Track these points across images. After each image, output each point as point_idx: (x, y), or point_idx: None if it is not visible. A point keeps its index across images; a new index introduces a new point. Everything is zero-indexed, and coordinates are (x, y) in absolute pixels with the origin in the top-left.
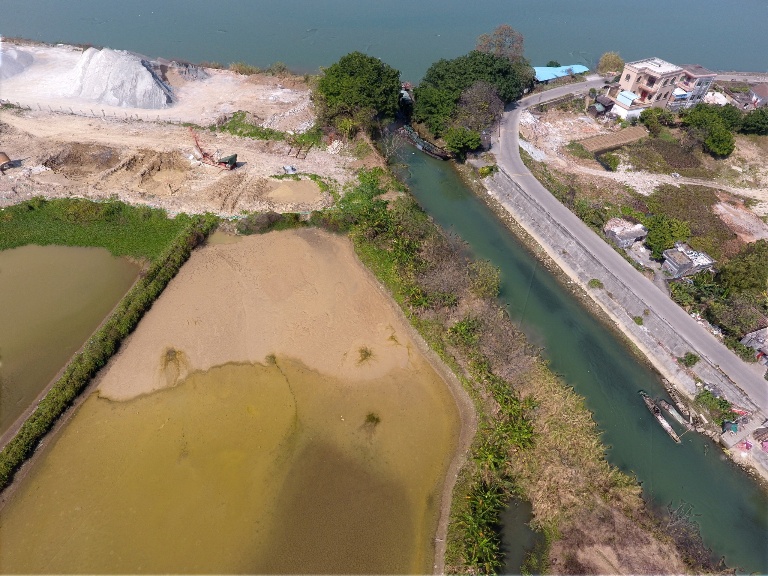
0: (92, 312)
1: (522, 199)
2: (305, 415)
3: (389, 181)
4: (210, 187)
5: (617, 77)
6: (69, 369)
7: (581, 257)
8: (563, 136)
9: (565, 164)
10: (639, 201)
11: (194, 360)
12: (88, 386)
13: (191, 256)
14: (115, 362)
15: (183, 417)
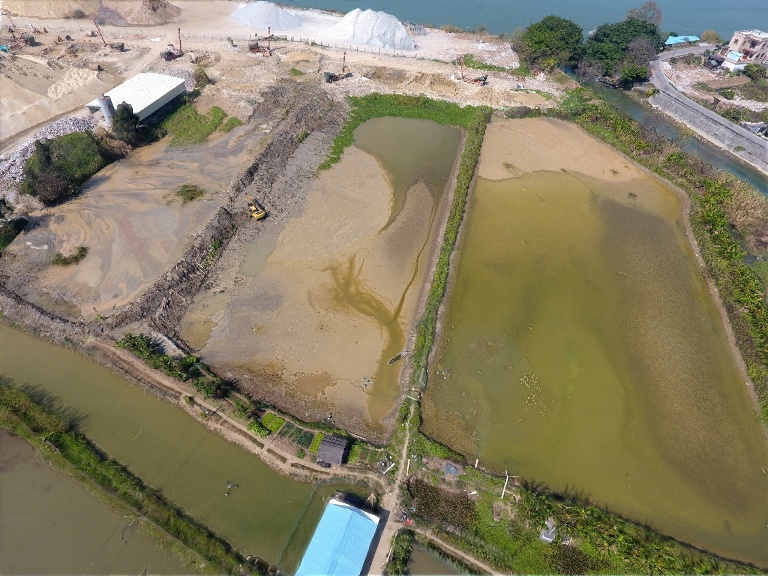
0: (448, 147)
1: (680, 107)
2: (596, 191)
3: (591, 94)
4: (477, 93)
5: (725, 43)
6: (463, 164)
7: (728, 135)
8: (691, 79)
9: (698, 94)
10: (754, 115)
11: (522, 168)
12: (474, 173)
13: (487, 126)
14: (480, 166)
15: (532, 188)
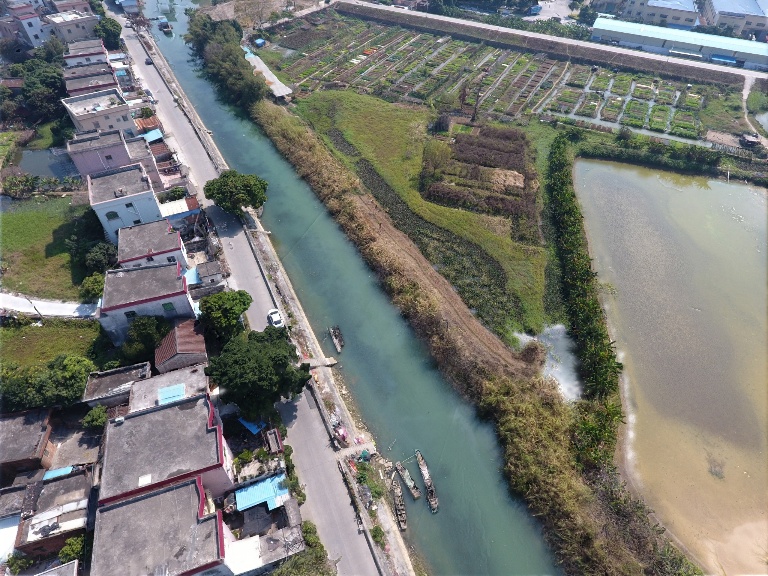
0: None
1: None
2: None
3: None
4: None
5: None
6: None
7: None
8: None
9: None
10: None
11: None
12: None
13: None
14: None
15: None
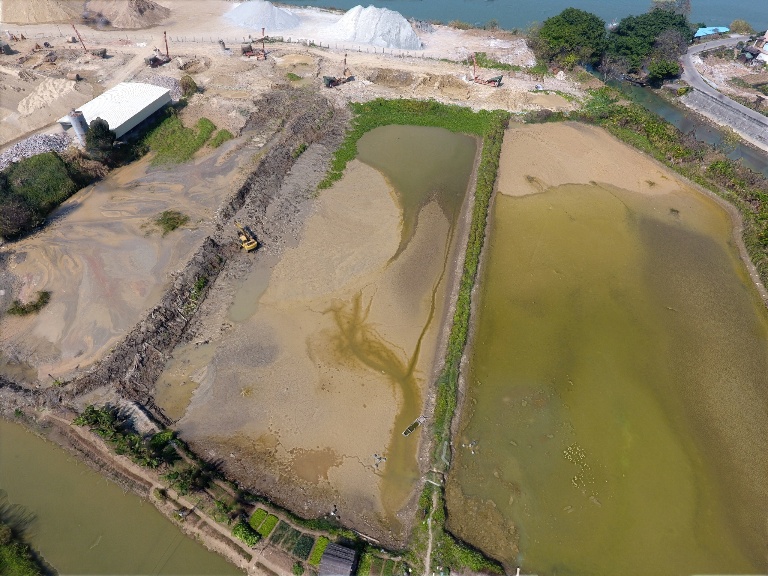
0: (463, 158)
1: (718, 107)
2: (632, 207)
3: (618, 94)
4: (492, 96)
5: (759, 33)
6: (481, 179)
7: None
8: (725, 74)
9: (734, 91)
10: None
11: (546, 181)
12: (493, 189)
13: (504, 133)
14: (499, 180)
15: (560, 205)
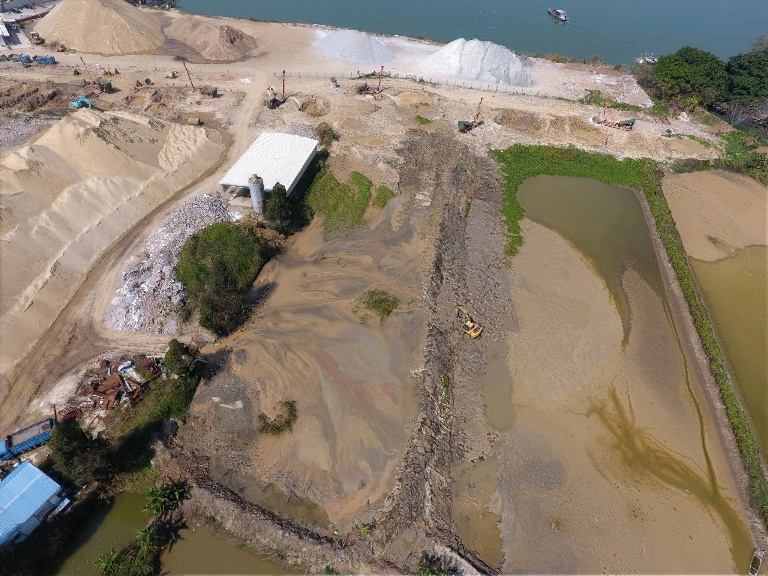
0: (632, 215)
1: None
2: None
3: (755, 140)
4: (629, 141)
5: None
6: (669, 242)
7: None
8: None
9: None
10: None
11: (730, 243)
12: None
13: None
14: (683, 242)
15: (757, 271)
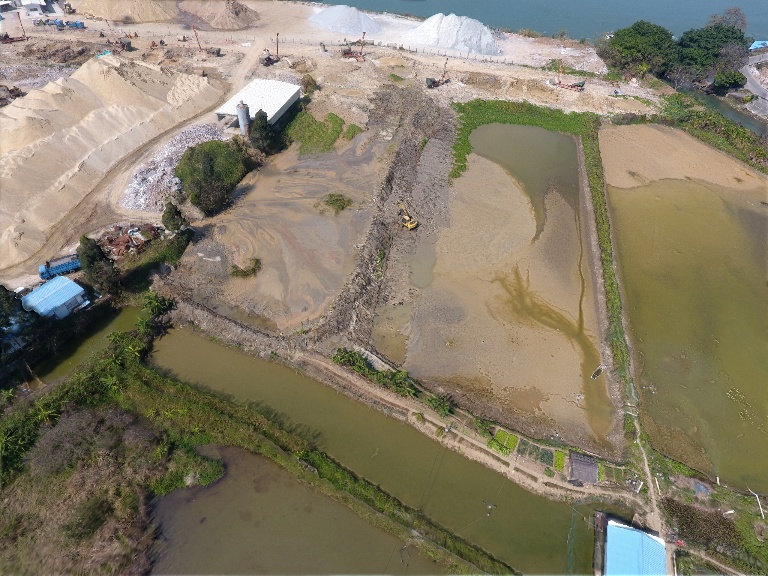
0: (567, 154)
1: None
2: (727, 200)
3: (691, 100)
4: (578, 99)
5: None
6: (591, 172)
7: None
8: None
9: None
10: None
11: (647, 176)
12: None
13: None
14: (605, 174)
15: (664, 196)
